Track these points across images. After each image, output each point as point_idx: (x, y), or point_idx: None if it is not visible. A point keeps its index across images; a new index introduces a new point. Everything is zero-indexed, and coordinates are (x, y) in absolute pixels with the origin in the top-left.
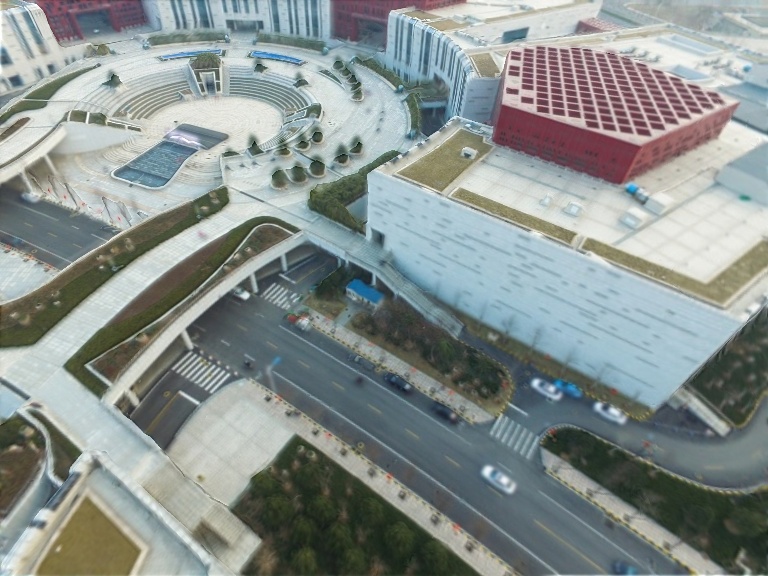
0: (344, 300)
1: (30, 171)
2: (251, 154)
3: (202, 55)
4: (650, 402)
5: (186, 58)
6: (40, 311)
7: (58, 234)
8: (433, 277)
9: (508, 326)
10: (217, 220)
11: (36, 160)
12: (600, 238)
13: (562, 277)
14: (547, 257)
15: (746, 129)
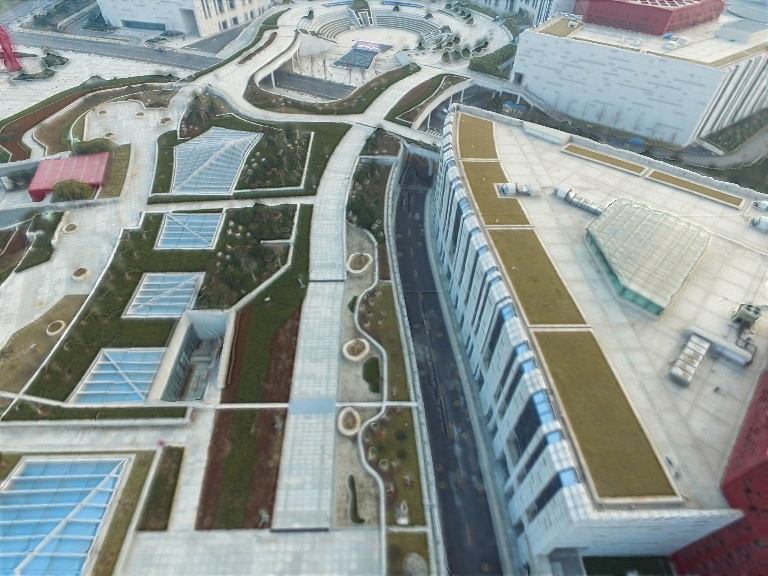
0: (501, 112)
1: (295, 57)
2: (419, 50)
3: (358, 0)
4: (681, 141)
5: (342, 5)
6: (357, 102)
7: (323, 88)
8: (553, 96)
9: (600, 115)
10: (421, 74)
11: (295, 52)
12: (654, 51)
13: (634, 71)
14: (627, 60)
15: (735, 17)
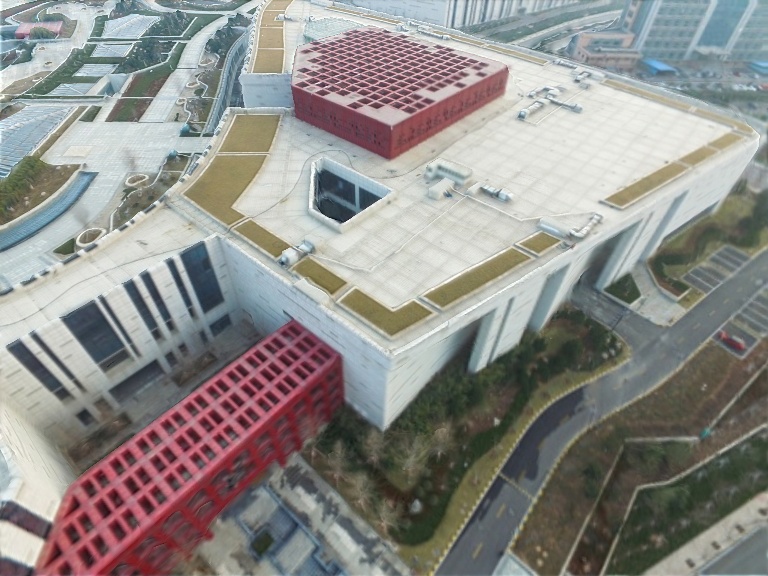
0: None
1: None
2: None
3: None
4: None
5: None
6: None
7: None
8: (368, 6)
9: None
10: None
11: None
12: None
13: None
14: None
15: None
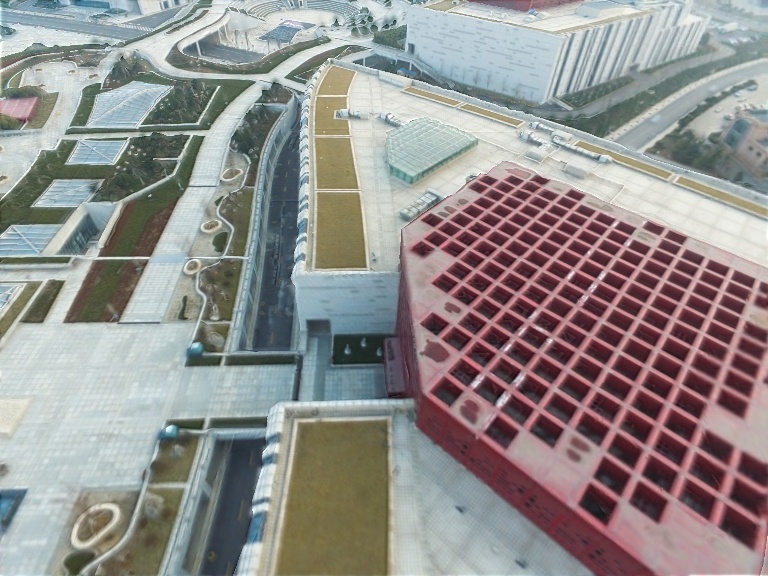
0: None
1: (221, 31)
2: (335, 26)
3: None
4: (538, 99)
5: None
6: None
7: (244, 57)
8: (440, 63)
9: (476, 78)
10: (329, 45)
11: (222, 26)
12: None
13: (496, 39)
14: (490, 30)
15: None
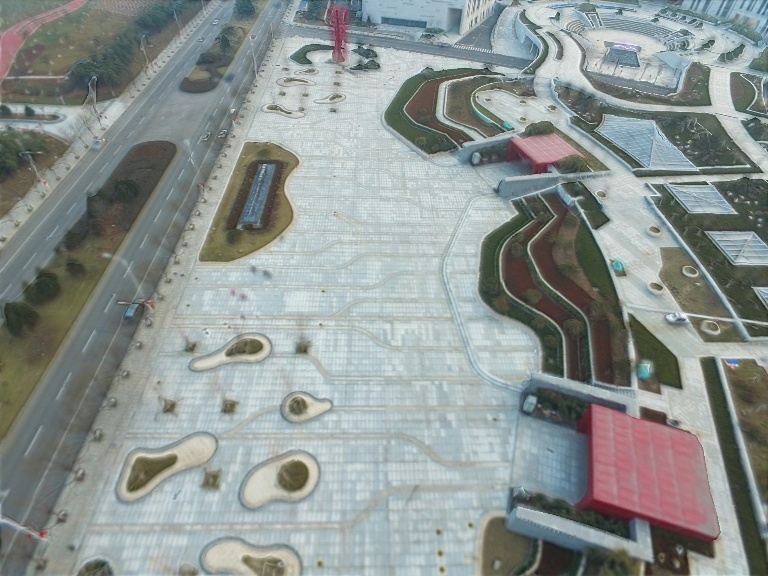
0: None
1: None
2: (684, 50)
3: (586, 4)
4: None
5: None
6: None
7: (621, 83)
8: None
9: None
10: (716, 72)
11: None
12: None
13: None
14: None
15: None
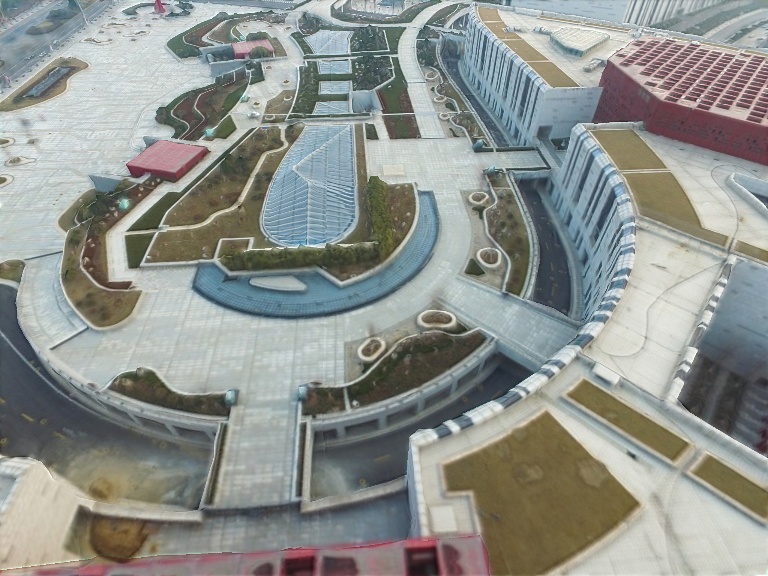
0: None
1: None
2: None
3: None
4: None
5: None
6: None
7: None
8: None
9: None
10: (442, 4)
11: None
12: None
13: None
14: None
15: None
